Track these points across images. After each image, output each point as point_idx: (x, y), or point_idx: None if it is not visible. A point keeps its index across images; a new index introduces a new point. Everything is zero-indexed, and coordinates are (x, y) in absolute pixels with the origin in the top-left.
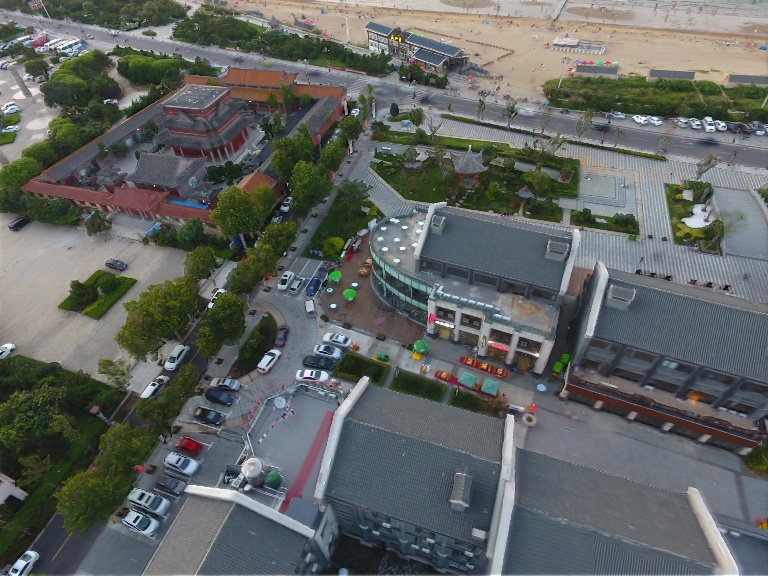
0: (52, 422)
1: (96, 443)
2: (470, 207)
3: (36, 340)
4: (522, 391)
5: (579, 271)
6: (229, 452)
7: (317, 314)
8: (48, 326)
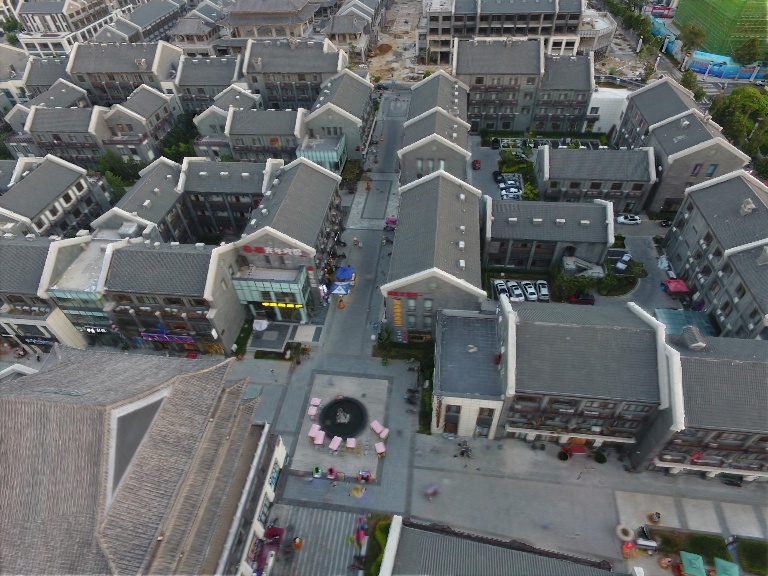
0: None
1: None
2: None
3: None
4: None
5: None
6: None
7: None
8: None
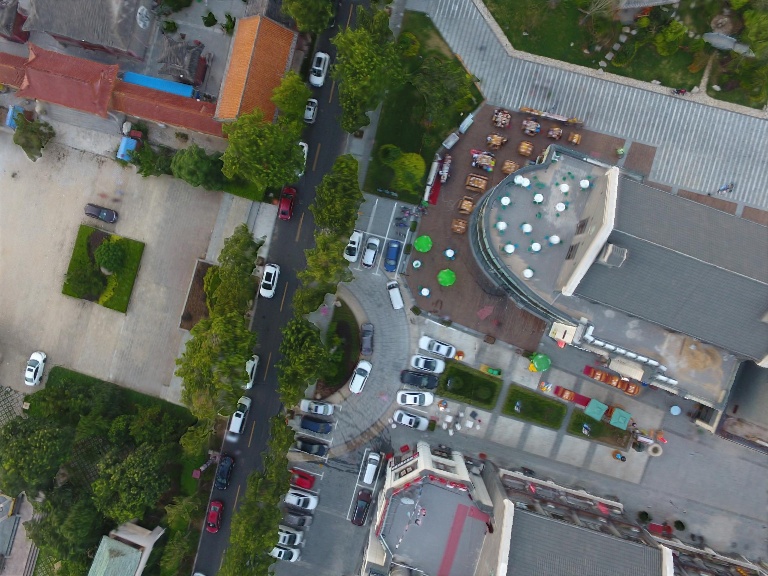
0: (169, 518)
1: (206, 479)
2: (623, 71)
3: (64, 344)
4: (652, 411)
5: (765, 219)
6: (343, 483)
7: (405, 302)
8: (66, 322)
